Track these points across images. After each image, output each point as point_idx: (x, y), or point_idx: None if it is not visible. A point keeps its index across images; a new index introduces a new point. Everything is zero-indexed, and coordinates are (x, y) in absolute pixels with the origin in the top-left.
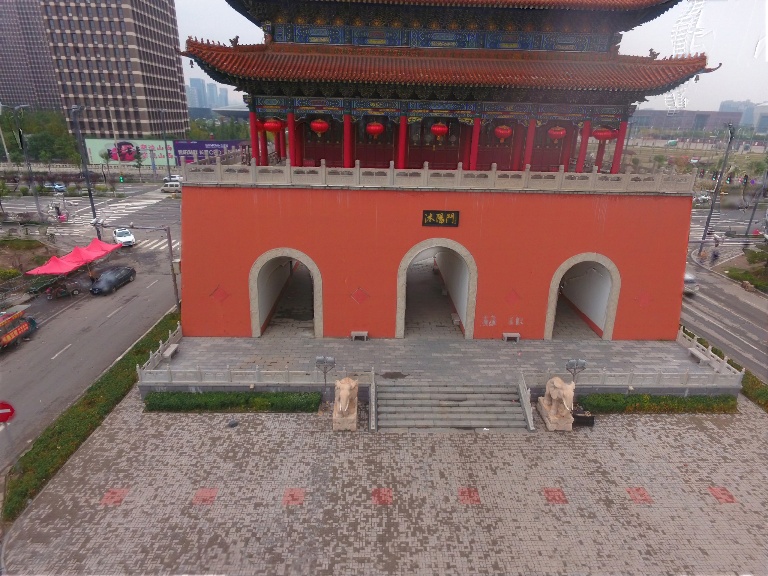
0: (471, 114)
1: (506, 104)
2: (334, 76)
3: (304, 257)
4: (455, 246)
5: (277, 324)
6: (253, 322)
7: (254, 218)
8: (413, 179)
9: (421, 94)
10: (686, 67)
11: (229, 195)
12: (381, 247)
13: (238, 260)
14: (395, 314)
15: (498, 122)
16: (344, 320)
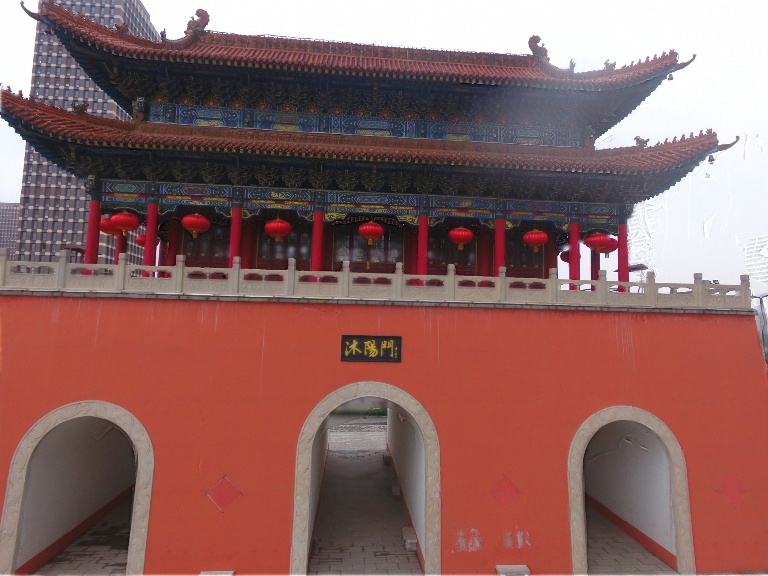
0: (414, 211)
1: (461, 199)
2: (211, 142)
3: (126, 418)
4: (397, 396)
5: (69, 558)
6: (0, 556)
7: (47, 347)
8: (326, 286)
9: (343, 183)
10: (692, 147)
11: (10, 308)
12: (269, 398)
13: (1, 425)
14: (290, 530)
15: (453, 223)
16: (189, 546)
